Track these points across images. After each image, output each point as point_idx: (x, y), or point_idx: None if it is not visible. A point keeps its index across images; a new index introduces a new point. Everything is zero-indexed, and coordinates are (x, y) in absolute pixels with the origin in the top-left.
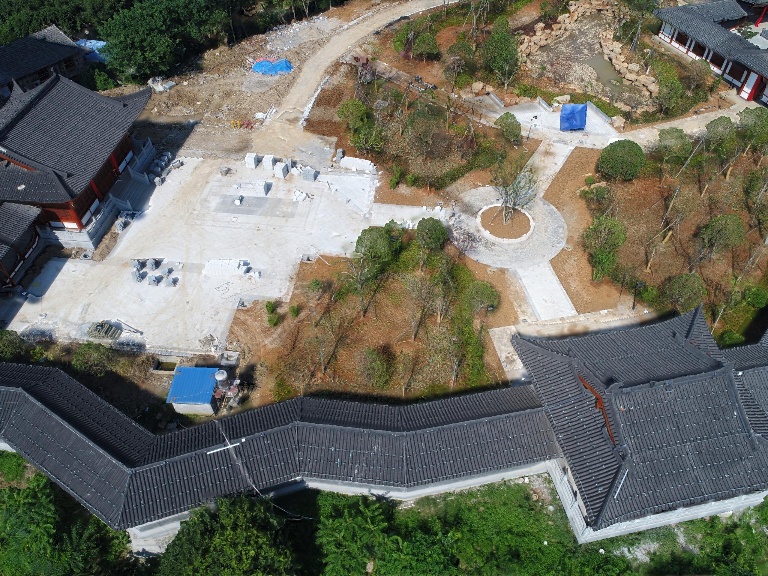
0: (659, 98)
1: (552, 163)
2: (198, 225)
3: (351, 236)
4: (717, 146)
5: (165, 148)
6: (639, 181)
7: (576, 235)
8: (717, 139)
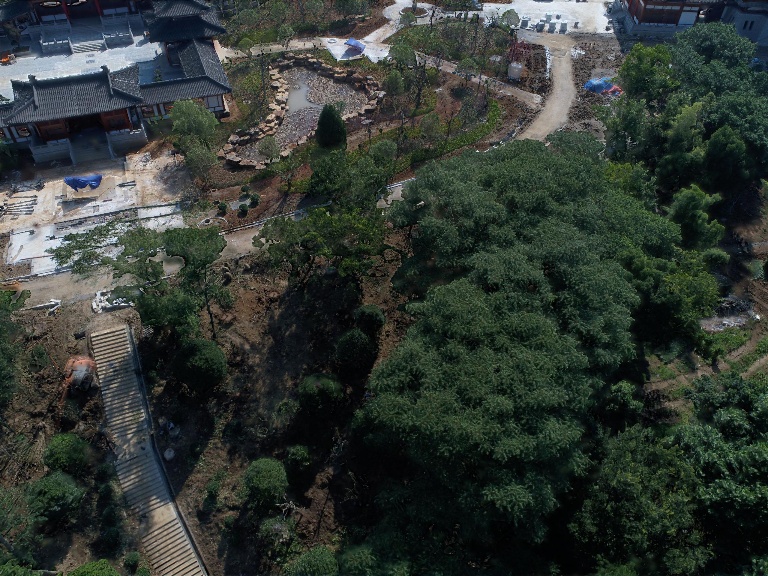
0: (280, 60)
1: (379, 33)
2: None
3: (492, 8)
4: None
5: (627, 38)
6: None
7: (380, 8)
8: None
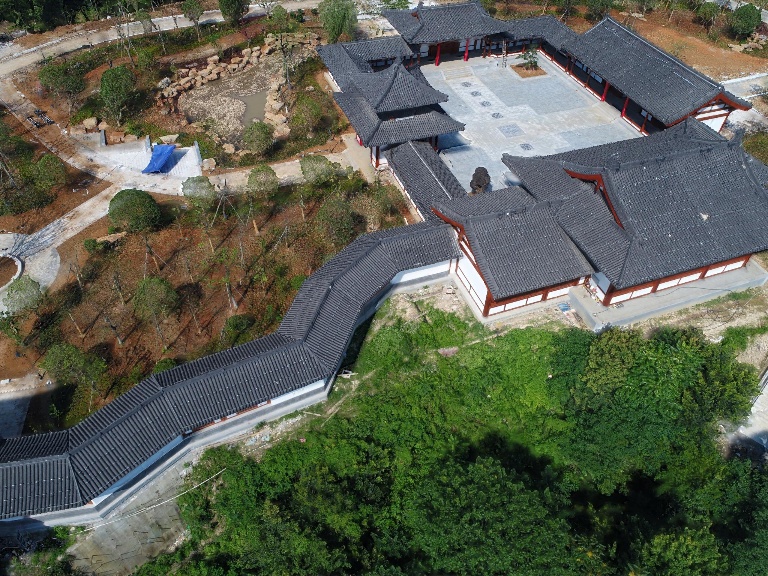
0: (273, 140)
1: (101, 209)
2: None
3: None
4: (267, 195)
5: None
6: (167, 232)
7: (52, 291)
8: (266, 188)
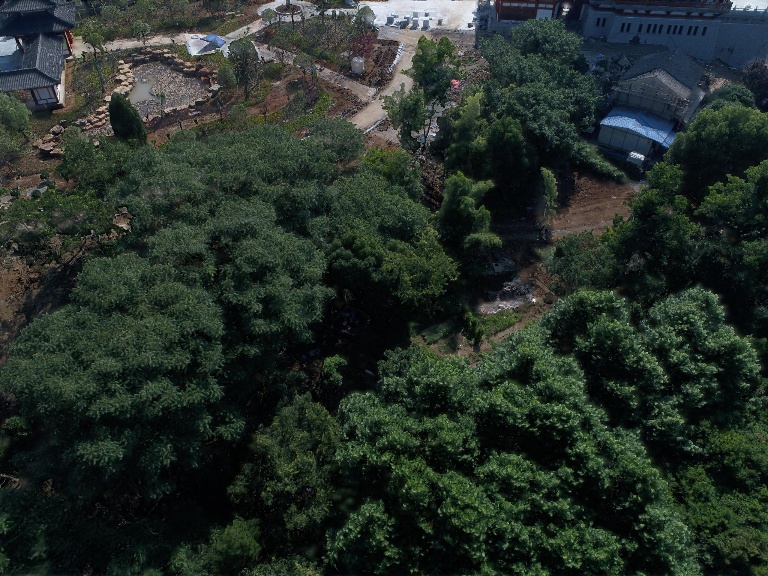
0: (134, 55)
1: (245, 29)
2: (443, 8)
3: None
4: None
5: None
6: None
7: (256, 6)
8: None
